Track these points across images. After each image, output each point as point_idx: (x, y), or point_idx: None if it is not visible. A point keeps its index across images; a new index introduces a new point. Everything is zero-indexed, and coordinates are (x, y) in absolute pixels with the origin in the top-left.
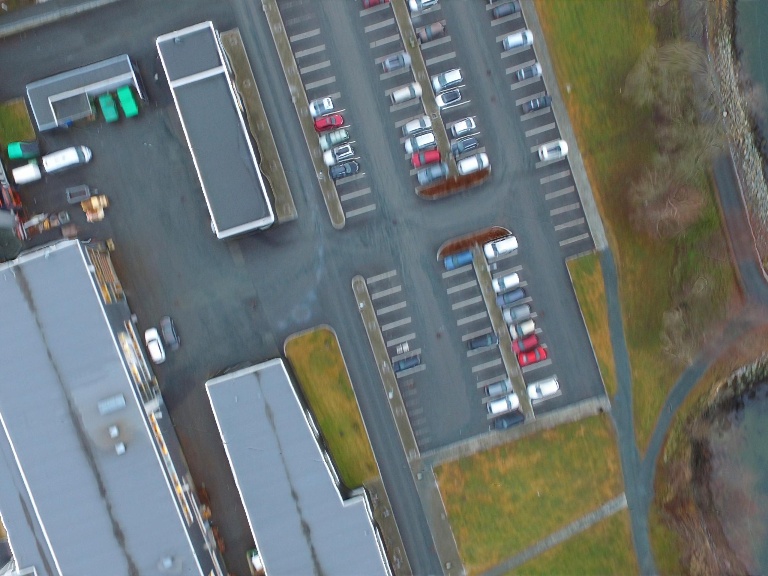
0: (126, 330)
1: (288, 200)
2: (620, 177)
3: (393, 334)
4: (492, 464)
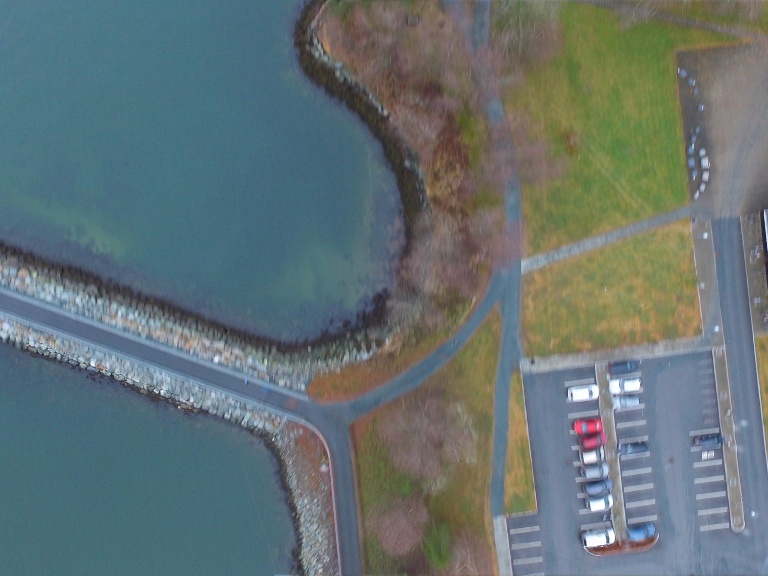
0: None
1: None
2: None
3: (715, 471)
4: (646, 327)
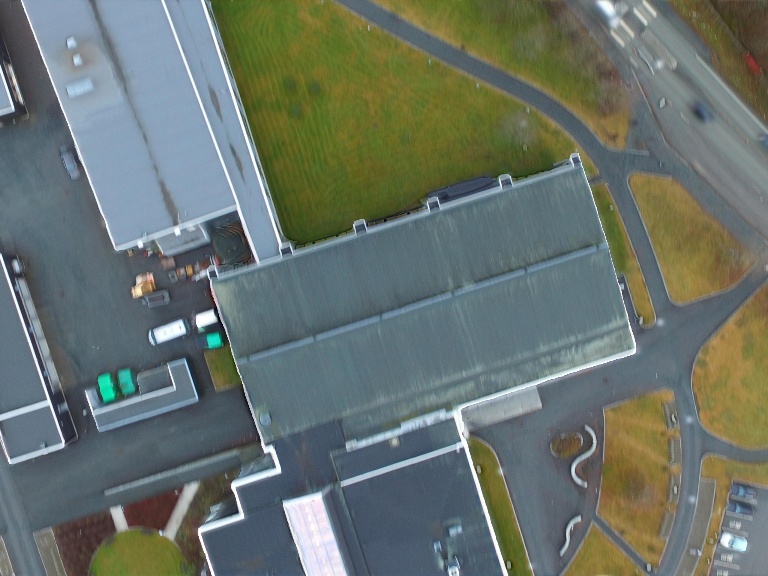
0: None
1: None
2: None
3: None
4: None
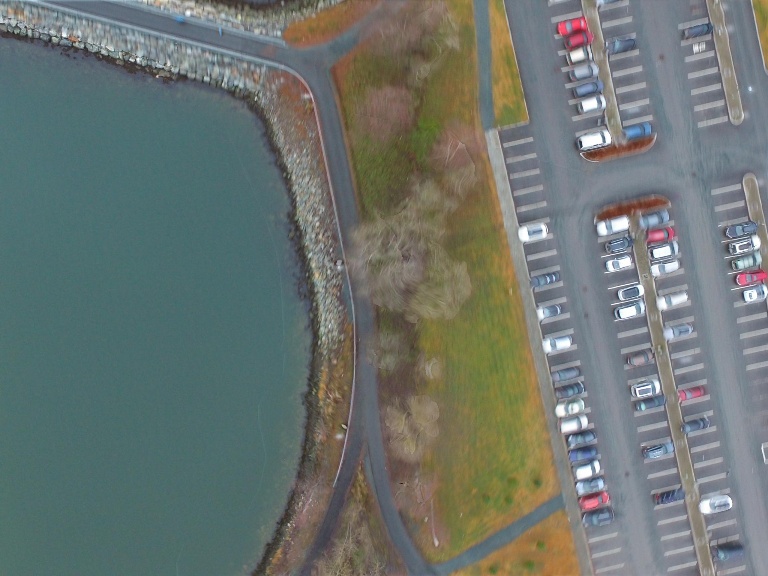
0: None
1: None
2: (469, 201)
3: (708, 63)
4: None
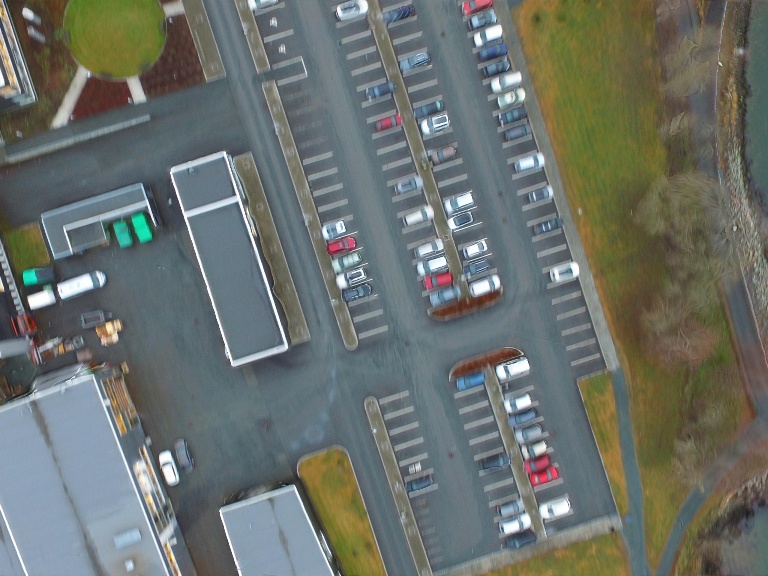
0: (141, 457)
1: (301, 322)
2: (631, 298)
3: (405, 454)
4: None
